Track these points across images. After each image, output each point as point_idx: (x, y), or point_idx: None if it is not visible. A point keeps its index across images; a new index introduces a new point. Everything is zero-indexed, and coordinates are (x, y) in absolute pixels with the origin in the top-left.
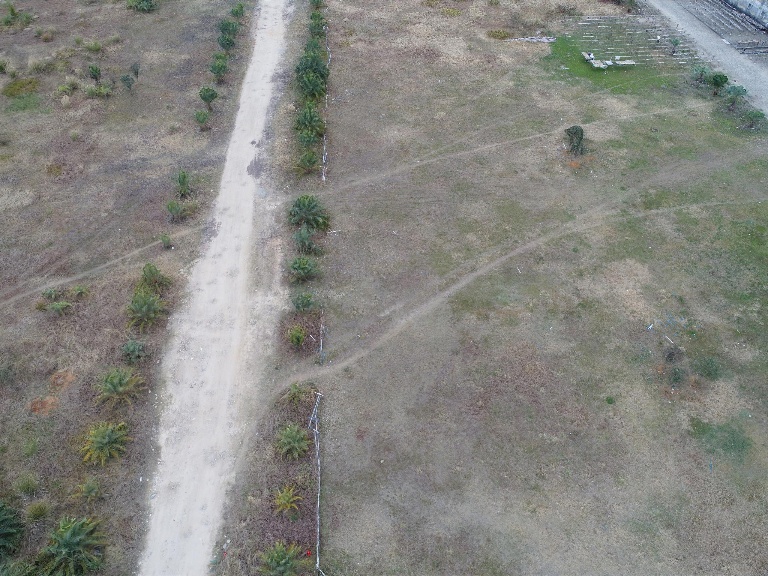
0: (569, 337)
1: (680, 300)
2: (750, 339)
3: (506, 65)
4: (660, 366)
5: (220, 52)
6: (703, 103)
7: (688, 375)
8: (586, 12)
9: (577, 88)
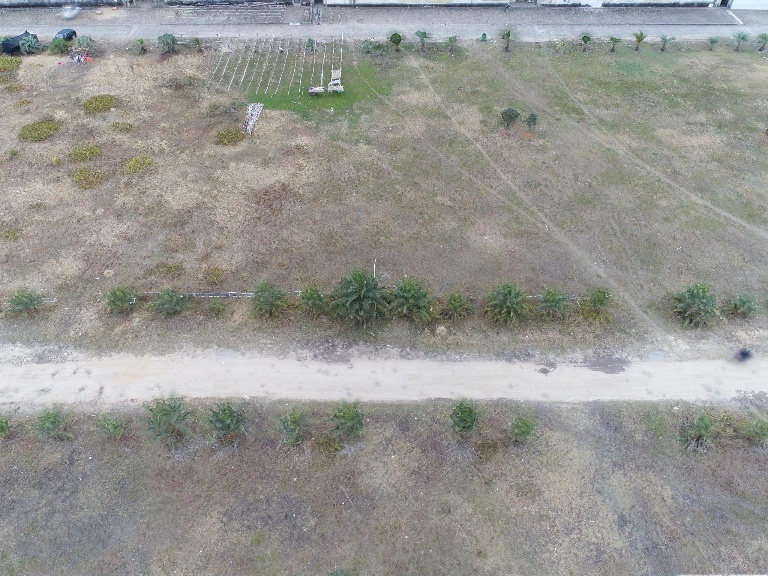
0: (757, 173)
1: (690, 124)
2: (712, 109)
3: (317, 143)
4: (762, 143)
5: (202, 456)
6: (411, 59)
7: (761, 136)
8: (191, 73)
9: (378, 110)
